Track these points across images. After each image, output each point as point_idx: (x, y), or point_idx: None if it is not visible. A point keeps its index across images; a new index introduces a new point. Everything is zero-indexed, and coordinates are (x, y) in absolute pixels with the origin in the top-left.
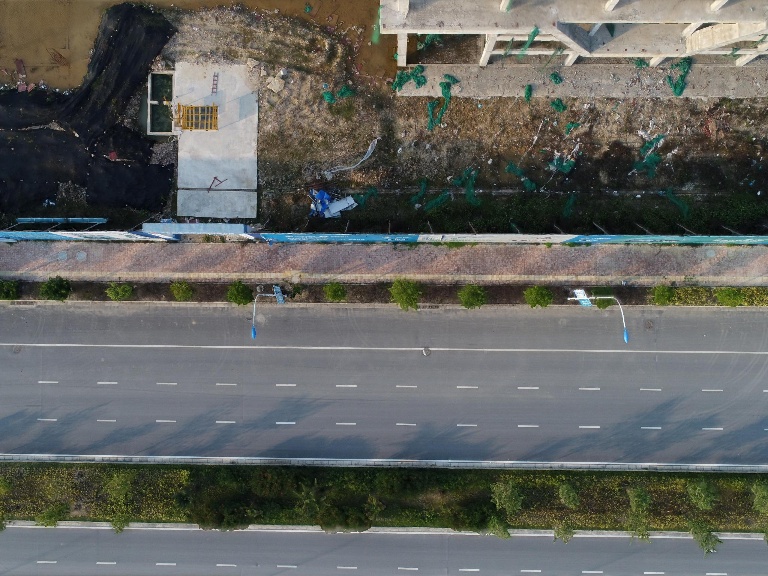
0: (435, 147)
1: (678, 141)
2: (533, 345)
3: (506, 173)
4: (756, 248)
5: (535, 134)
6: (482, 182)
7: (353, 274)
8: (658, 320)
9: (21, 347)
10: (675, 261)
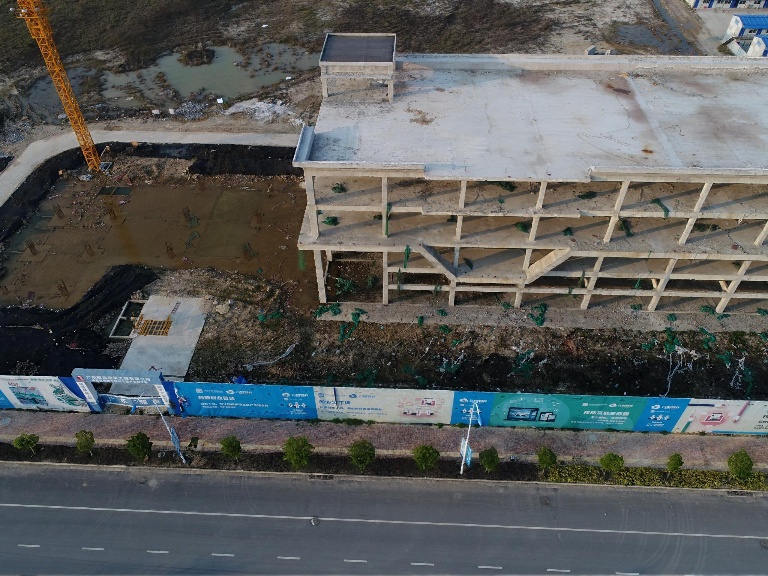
0: (343, 353)
1: (546, 354)
2: (427, 518)
3: (403, 373)
4: (634, 434)
5: (427, 346)
6: (381, 378)
7: (254, 445)
8: (554, 497)
9: None
10: (560, 443)
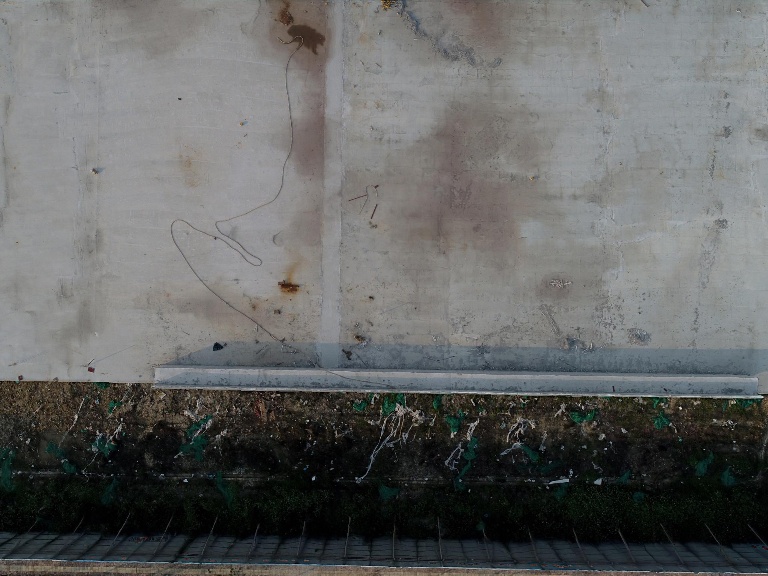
0: None
1: (227, 422)
2: None
3: (46, 453)
4: None
5: (76, 413)
6: (19, 464)
7: None
8: None
9: None
10: None
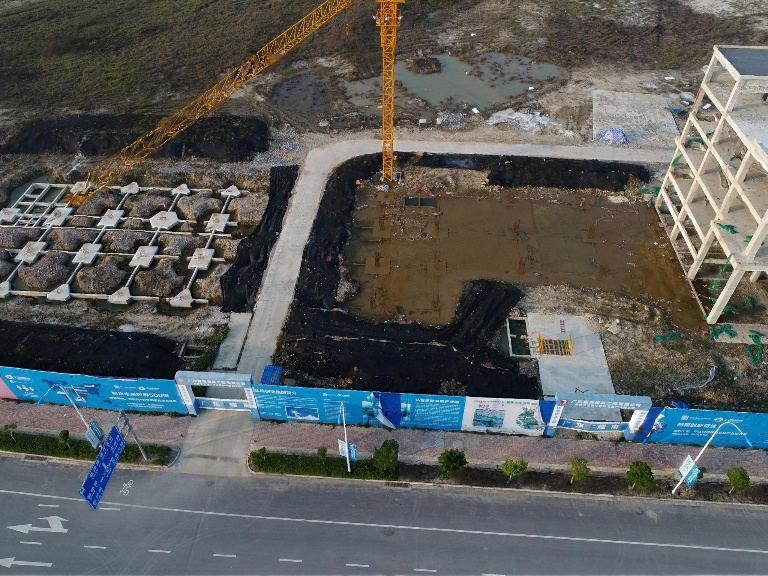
0: (766, 378)
1: None
2: None
3: None
4: None
5: None
6: None
7: None
8: None
9: (395, 529)
10: None
